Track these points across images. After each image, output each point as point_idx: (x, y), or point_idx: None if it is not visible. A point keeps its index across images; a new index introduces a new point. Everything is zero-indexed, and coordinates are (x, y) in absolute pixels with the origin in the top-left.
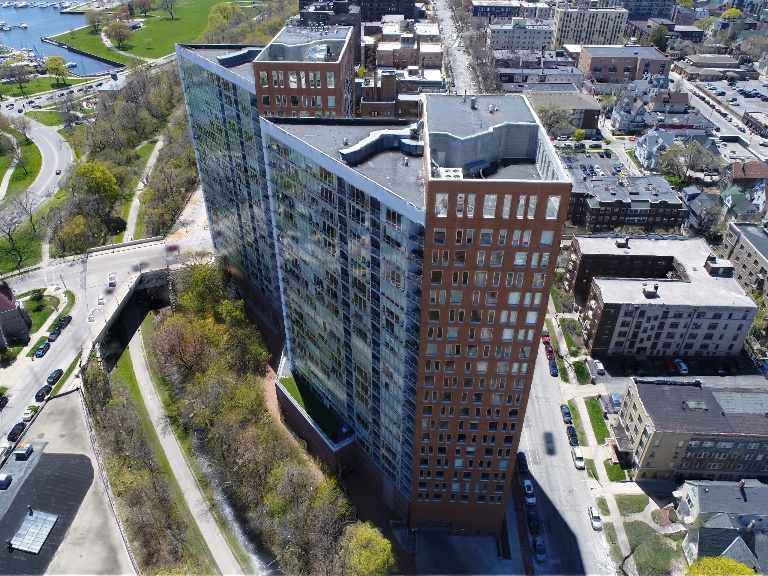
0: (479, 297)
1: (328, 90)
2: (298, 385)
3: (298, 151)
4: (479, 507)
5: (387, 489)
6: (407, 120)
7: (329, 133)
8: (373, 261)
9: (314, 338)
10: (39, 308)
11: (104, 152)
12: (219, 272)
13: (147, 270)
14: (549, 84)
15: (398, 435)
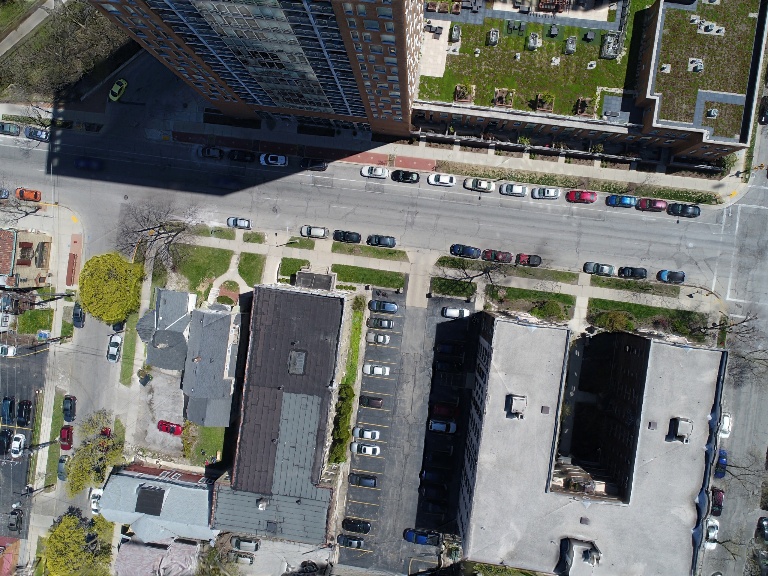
0: None
1: None
2: None
3: None
4: None
5: None
6: None
7: None
8: None
9: None
10: None
11: None
12: None
13: None
14: None
15: None
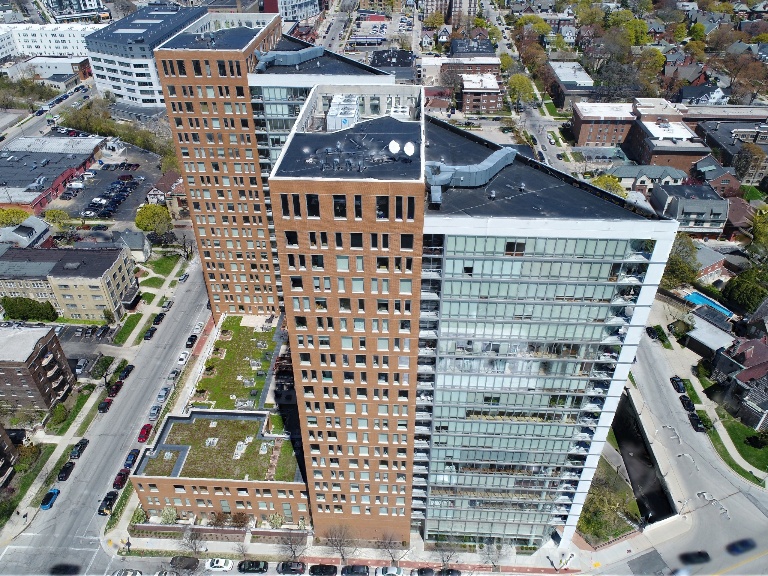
0: None
1: None
2: None
3: None
4: None
5: None
6: (261, 74)
7: (331, 73)
8: None
9: None
10: (756, 443)
11: None
12: None
13: (681, 534)
14: None
15: None
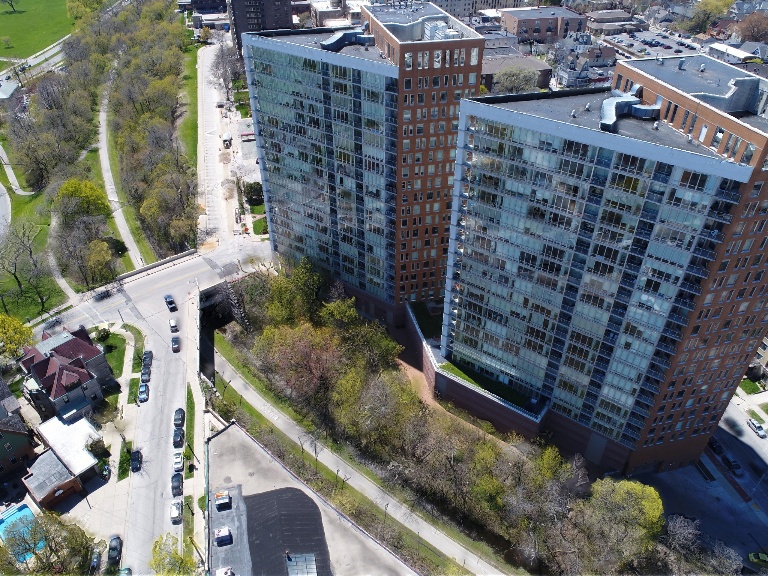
0: (766, 242)
1: (471, 67)
2: (461, 369)
3: (530, 129)
4: (691, 440)
5: (594, 446)
6: (599, 88)
7: (541, 108)
8: (638, 226)
9: (499, 317)
10: (107, 349)
11: (59, 168)
12: (311, 274)
13: (202, 287)
14: (491, 49)
15: (631, 390)
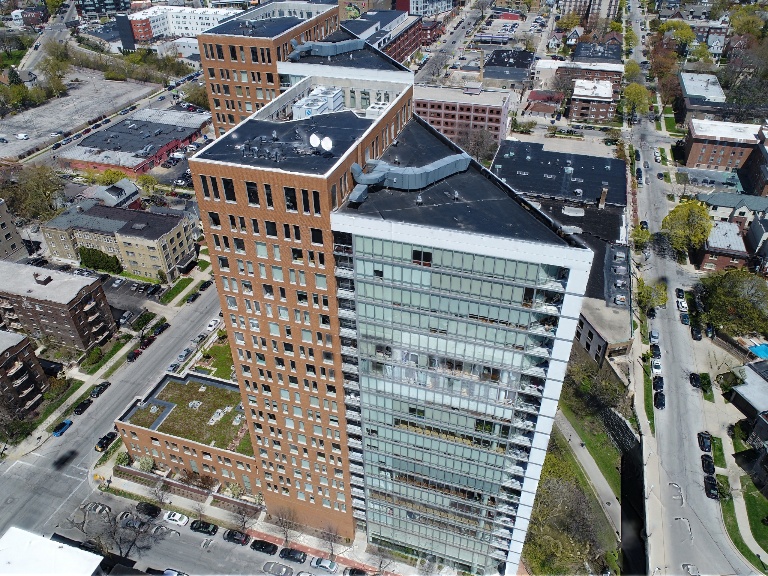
0: None
1: None
2: None
3: None
4: None
5: None
6: (289, 62)
7: (359, 66)
8: None
9: None
10: None
11: None
12: None
13: None
14: None
15: None
